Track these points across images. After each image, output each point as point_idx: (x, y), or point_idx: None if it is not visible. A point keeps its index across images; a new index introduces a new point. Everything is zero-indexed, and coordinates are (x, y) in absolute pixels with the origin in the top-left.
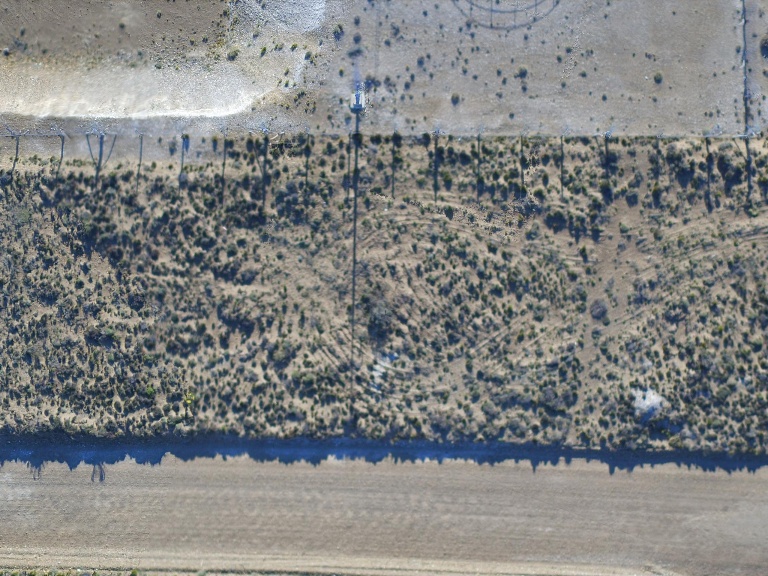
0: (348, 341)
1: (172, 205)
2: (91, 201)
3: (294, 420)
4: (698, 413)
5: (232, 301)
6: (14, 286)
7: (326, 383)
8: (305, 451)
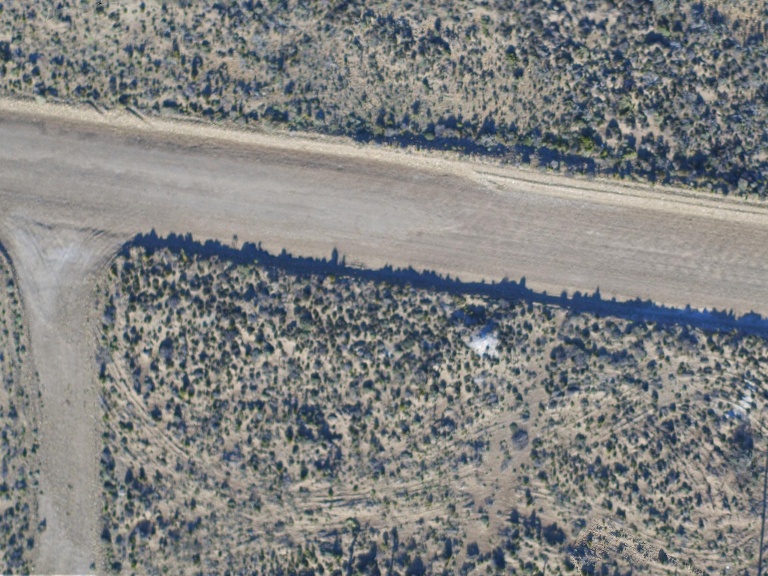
0: None
1: None
2: None
3: None
4: (436, 327)
5: None
6: None
7: None
8: None
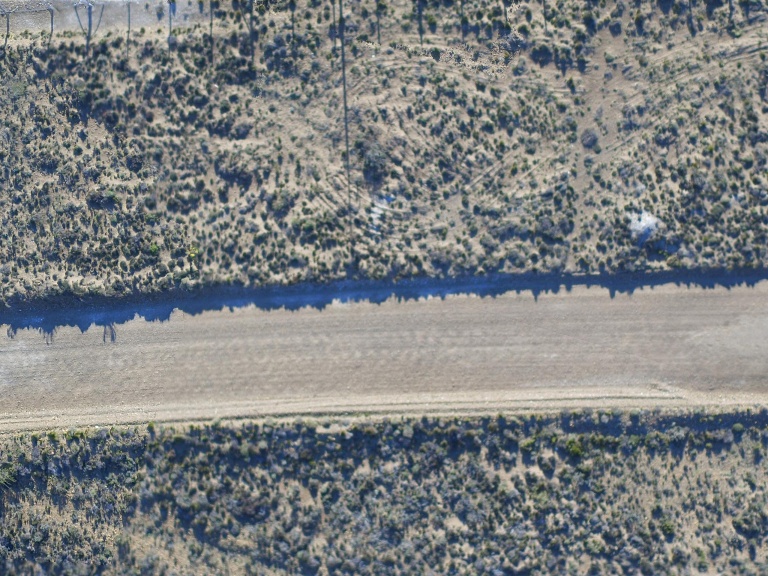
0: (345, 186)
1: (163, 67)
2: (83, 69)
3: (297, 266)
4: (694, 232)
5: (228, 156)
6: (14, 158)
7: (326, 228)
8: (310, 297)
